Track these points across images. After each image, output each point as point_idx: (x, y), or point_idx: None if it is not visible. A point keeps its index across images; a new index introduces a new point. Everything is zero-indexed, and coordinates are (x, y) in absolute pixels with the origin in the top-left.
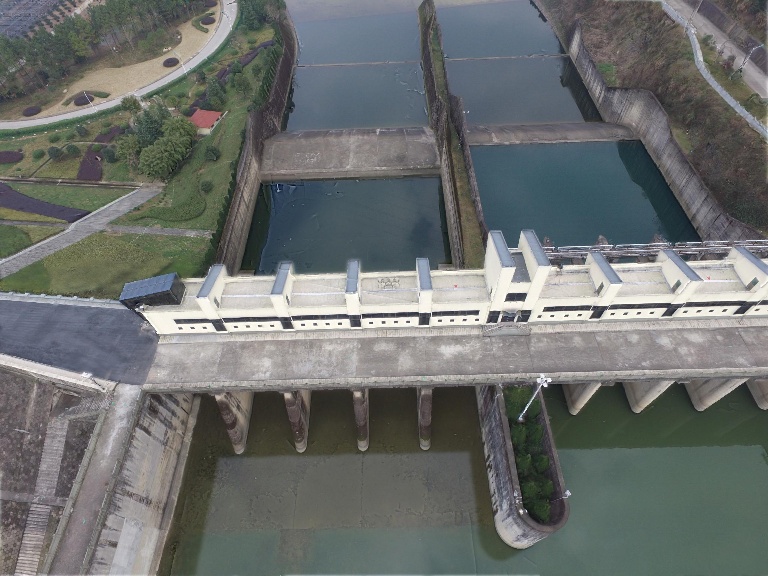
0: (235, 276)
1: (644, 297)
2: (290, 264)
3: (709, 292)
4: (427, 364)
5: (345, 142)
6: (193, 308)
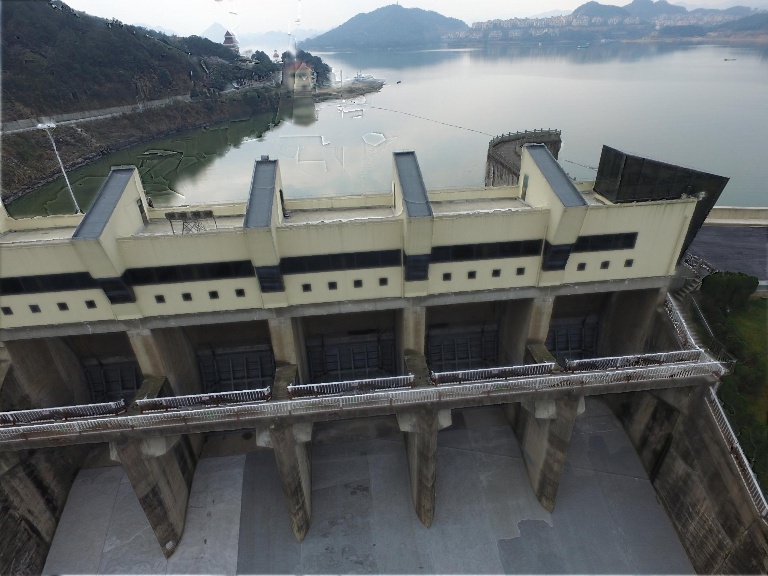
0: None
1: None
2: (408, 211)
3: None
4: None
5: None
6: None
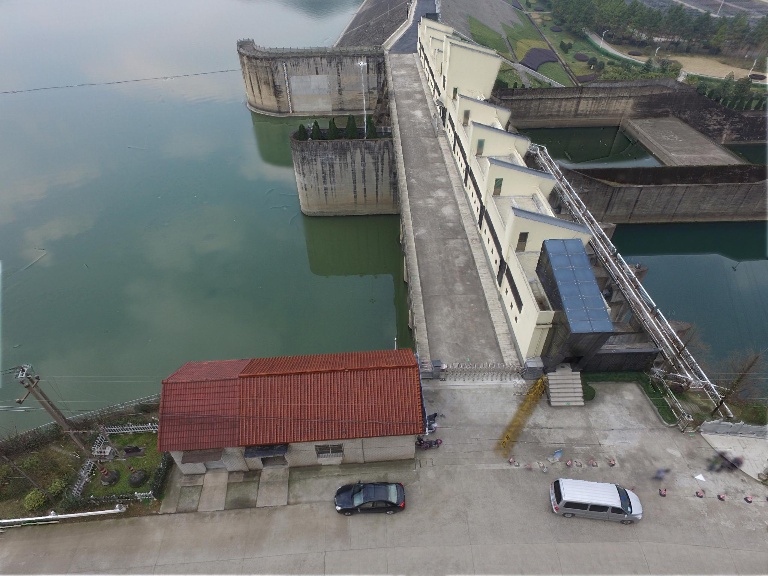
0: None
1: None
2: (458, 37)
3: None
4: (406, 107)
5: (714, 151)
6: None
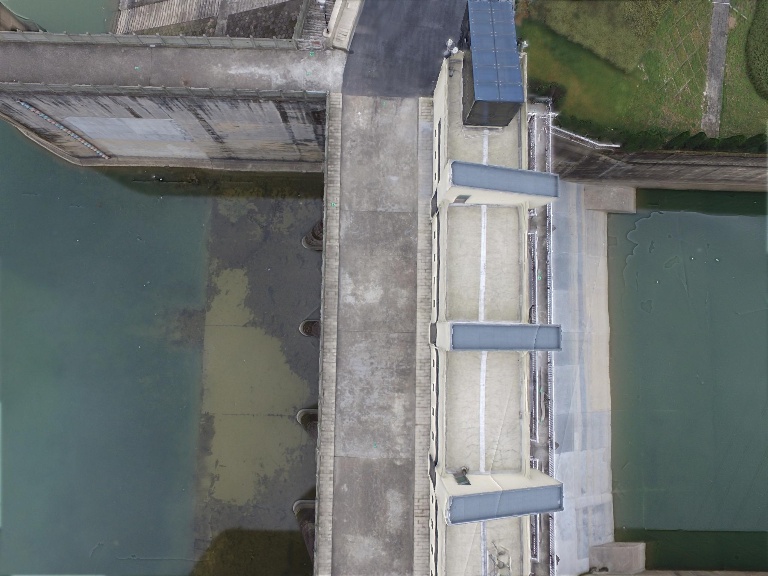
0: (621, 183)
1: None
2: (554, 349)
3: None
4: None
5: None
6: (457, 152)
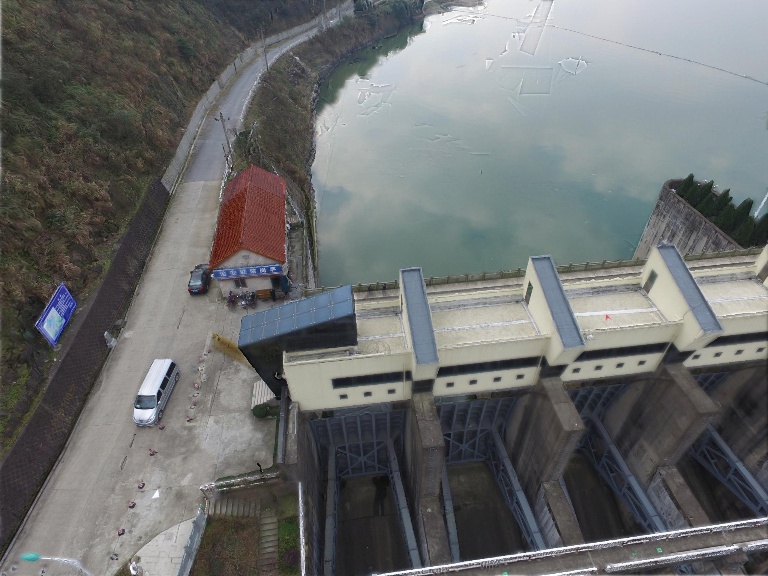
0: None
1: (707, 274)
2: None
3: (616, 278)
4: None
5: None
6: None
